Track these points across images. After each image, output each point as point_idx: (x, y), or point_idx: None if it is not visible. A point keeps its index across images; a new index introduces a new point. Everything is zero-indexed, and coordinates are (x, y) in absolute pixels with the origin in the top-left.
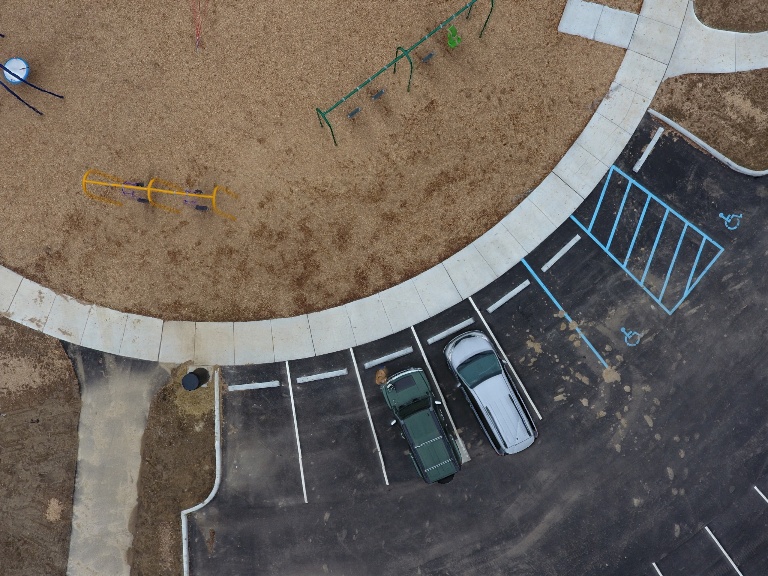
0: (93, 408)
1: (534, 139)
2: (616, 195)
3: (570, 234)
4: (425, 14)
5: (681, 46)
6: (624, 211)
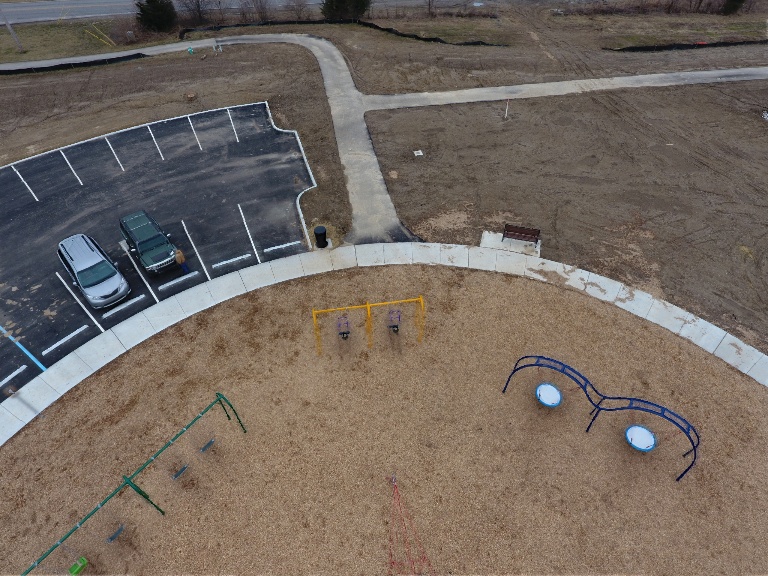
0: (389, 216)
1: (1, 486)
2: None
3: None
4: None
5: None
6: None
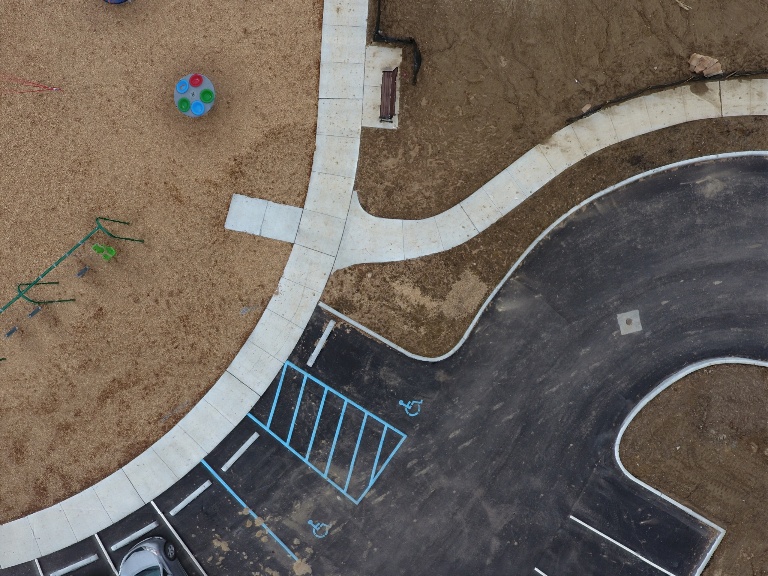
0: None
1: (206, 339)
2: (292, 390)
3: (249, 432)
4: (87, 221)
5: (348, 237)
6: (302, 405)
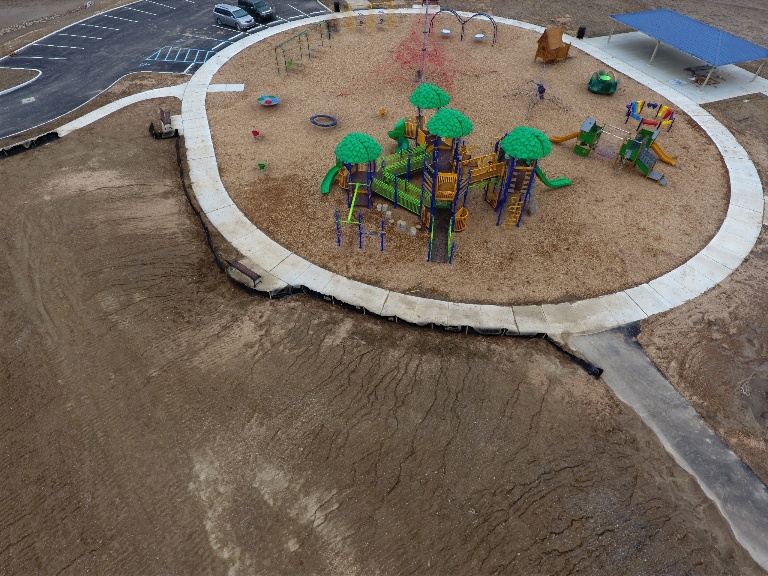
0: None
1: None
2: None
3: None
4: None
5: None
6: None
